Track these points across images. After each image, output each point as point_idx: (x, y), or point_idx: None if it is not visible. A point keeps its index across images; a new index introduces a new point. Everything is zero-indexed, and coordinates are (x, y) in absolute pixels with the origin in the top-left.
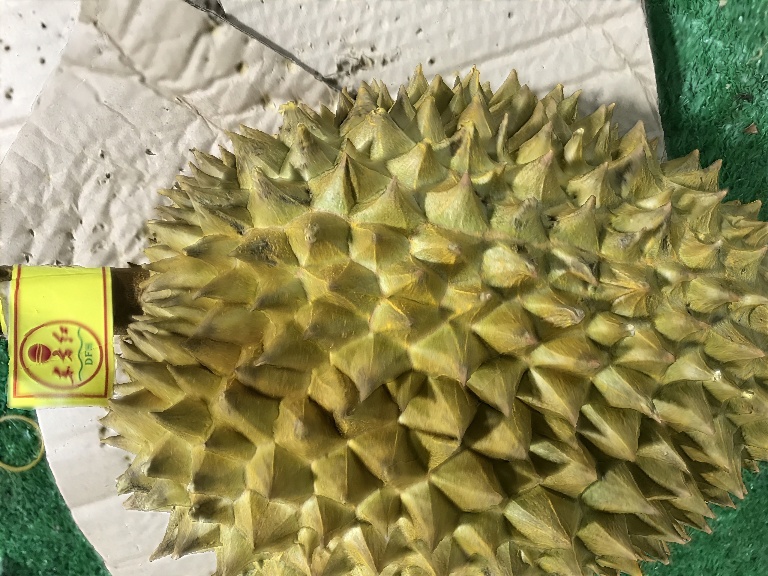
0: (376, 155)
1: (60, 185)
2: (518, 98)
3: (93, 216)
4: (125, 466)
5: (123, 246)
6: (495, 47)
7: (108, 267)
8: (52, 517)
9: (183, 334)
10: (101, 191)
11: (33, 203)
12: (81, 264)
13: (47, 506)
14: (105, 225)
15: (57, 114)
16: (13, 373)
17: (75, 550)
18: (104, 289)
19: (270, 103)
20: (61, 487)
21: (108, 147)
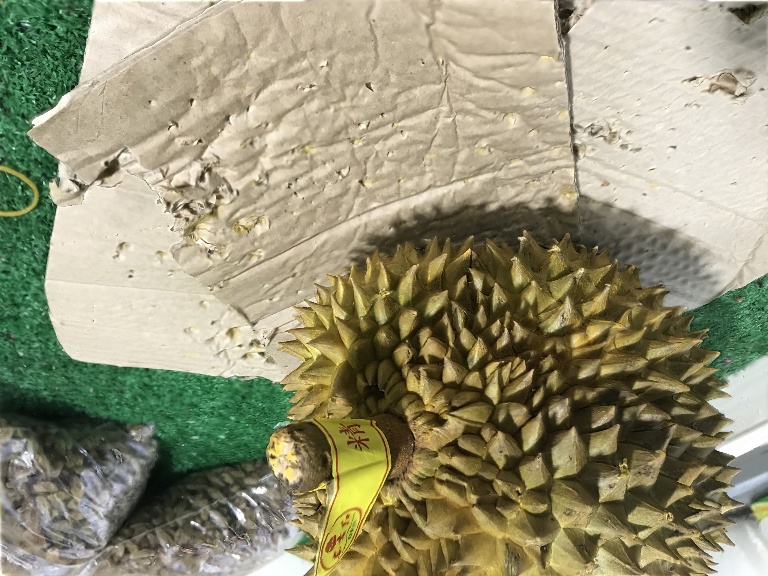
0: (642, 537)
1: (257, 71)
2: (706, 412)
3: (266, 113)
4: (126, 276)
5: (274, 152)
6: (699, 191)
7: (387, 443)
8: (2, 251)
9: (442, 572)
10: (293, 95)
11: (214, 75)
12: (222, 150)
13: (1, 242)
14: (270, 124)
15: (313, 2)
16: (316, 570)
17: (10, 277)
18: (384, 477)
19: (513, 116)
20: (50, 268)
21: (335, 61)
